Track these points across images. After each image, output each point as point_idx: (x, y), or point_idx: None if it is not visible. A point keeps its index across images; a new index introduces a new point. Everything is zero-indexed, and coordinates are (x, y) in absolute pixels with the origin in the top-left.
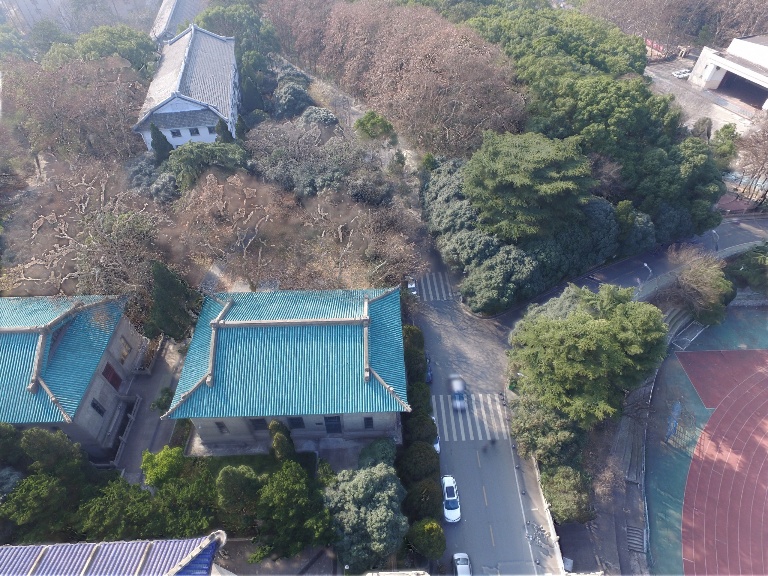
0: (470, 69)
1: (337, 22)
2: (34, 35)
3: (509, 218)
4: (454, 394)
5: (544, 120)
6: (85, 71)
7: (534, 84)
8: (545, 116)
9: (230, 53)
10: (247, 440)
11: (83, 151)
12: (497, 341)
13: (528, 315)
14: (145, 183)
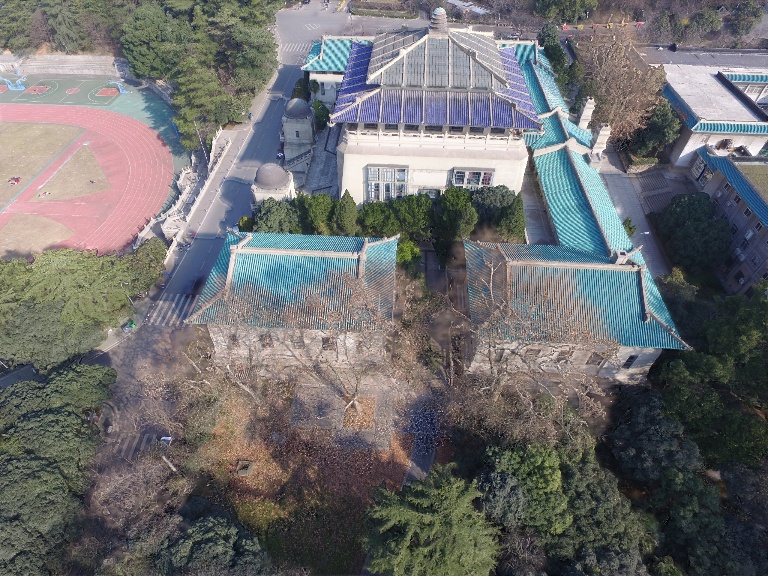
0: None
1: None
2: None
3: None
4: (185, 327)
5: None
6: None
7: None
8: None
9: None
10: None
11: None
12: None
13: (69, 338)
14: None
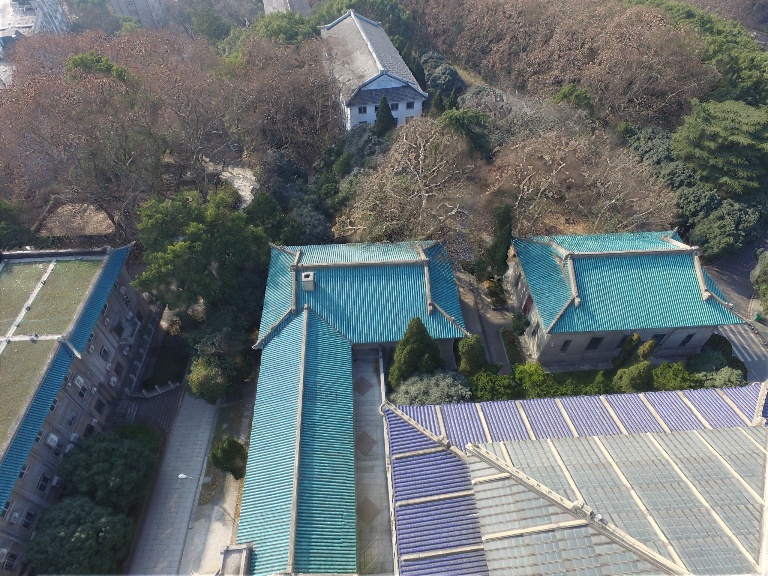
0: (669, 45)
1: (484, 7)
2: (199, 21)
3: (729, 175)
4: None
5: (734, 90)
6: (317, 49)
7: (718, 59)
8: (732, 87)
9: (386, 37)
10: (574, 360)
11: (304, 125)
12: (724, 283)
13: None
14: (380, 151)
